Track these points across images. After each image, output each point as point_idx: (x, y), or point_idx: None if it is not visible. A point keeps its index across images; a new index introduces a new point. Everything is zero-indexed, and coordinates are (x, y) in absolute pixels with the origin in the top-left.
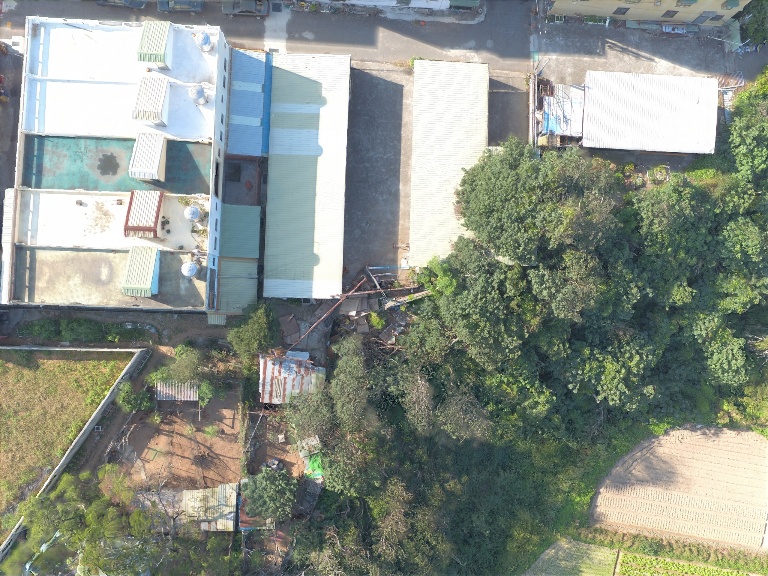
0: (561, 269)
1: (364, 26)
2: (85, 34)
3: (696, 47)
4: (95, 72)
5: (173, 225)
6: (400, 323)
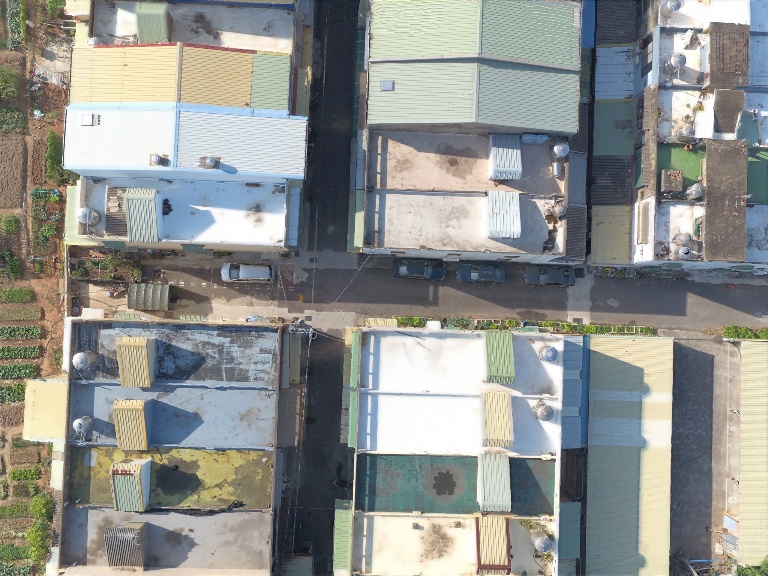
0: None
1: (671, 291)
2: (417, 342)
3: None
4: (429, 383)
5: (514, 548)
6: None
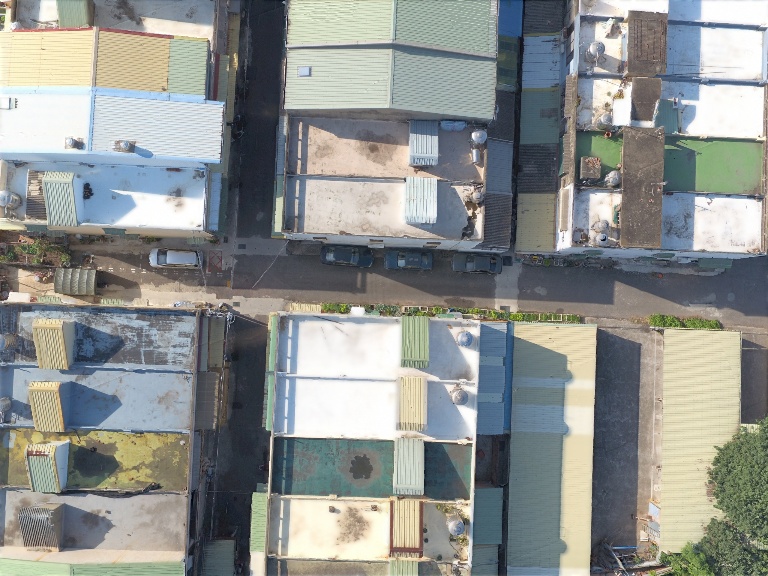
0: None
1: (599, 280)
2: (335, 326)
3: None
4: (346, 368)
5: (430, 532)
6: None
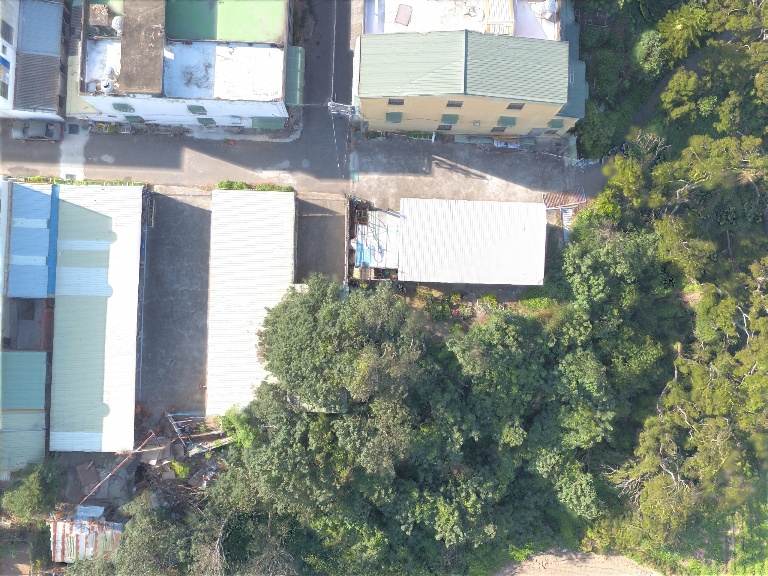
0: (371, 417)
1: (169, 147)
2: None
3: (532, 162)
4: None
5: None
6: (211, 467)
